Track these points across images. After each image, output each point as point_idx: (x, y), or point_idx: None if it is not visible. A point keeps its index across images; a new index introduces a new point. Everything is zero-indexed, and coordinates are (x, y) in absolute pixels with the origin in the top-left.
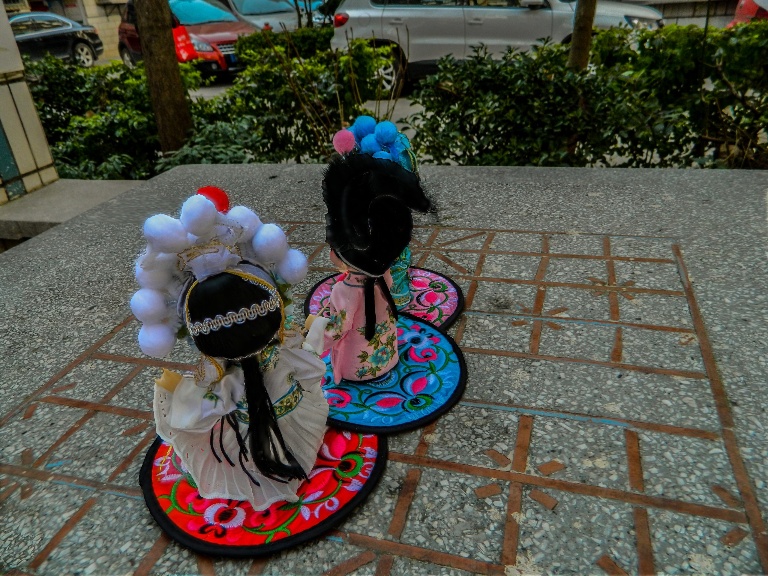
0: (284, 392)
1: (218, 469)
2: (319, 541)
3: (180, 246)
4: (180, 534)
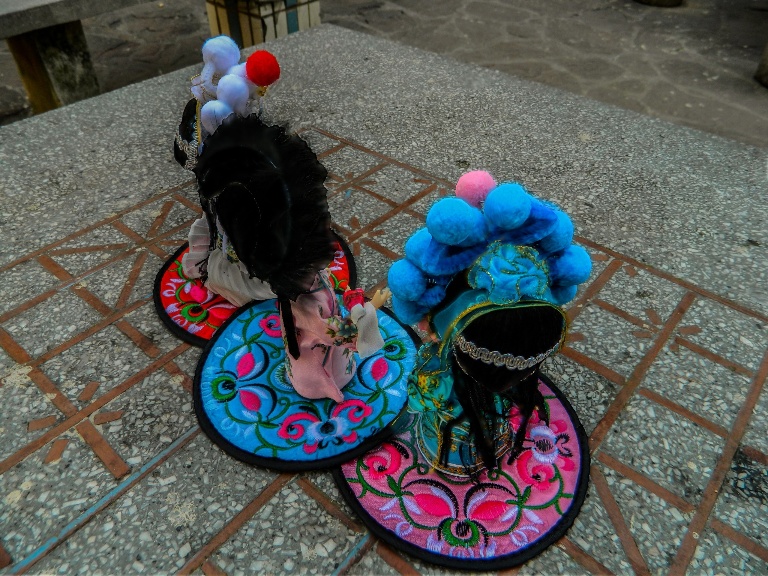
0: None
1: None
2: None
3: None
4: None
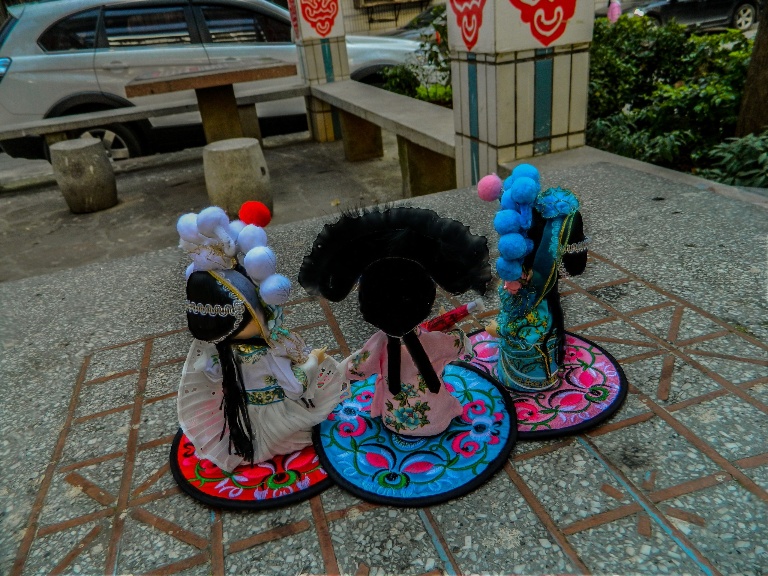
0: (259, 387)
1: (209, 412)
2: (207, 508)
3: (192, 241)
4: (178, 437)
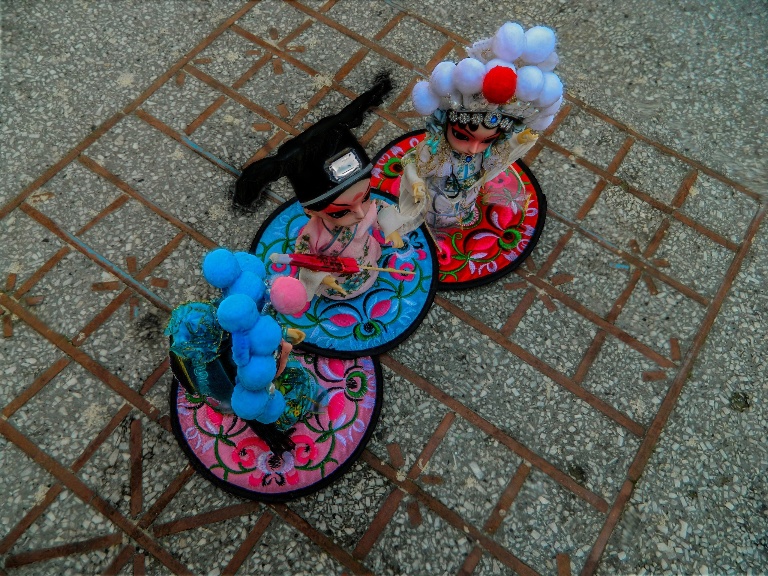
0: None
1: None
2: None
3: None
4: None
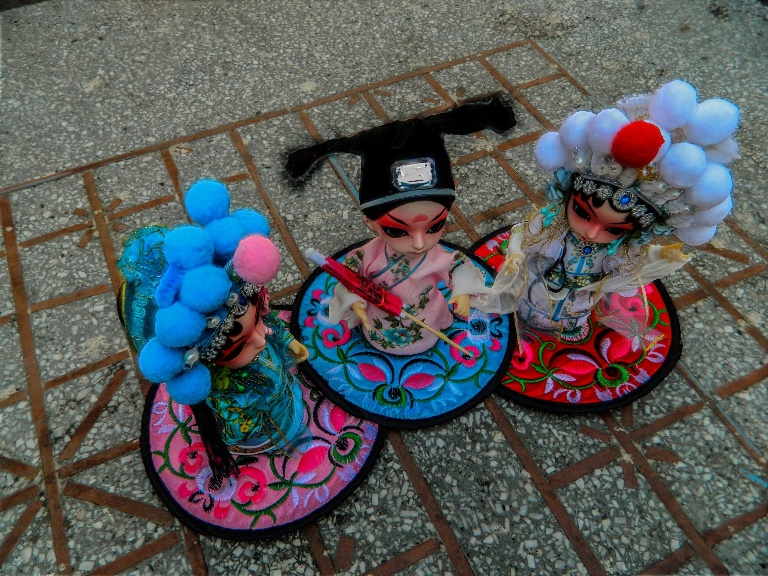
0: None
1: None
2: None
3: None
4: (661, 287)
